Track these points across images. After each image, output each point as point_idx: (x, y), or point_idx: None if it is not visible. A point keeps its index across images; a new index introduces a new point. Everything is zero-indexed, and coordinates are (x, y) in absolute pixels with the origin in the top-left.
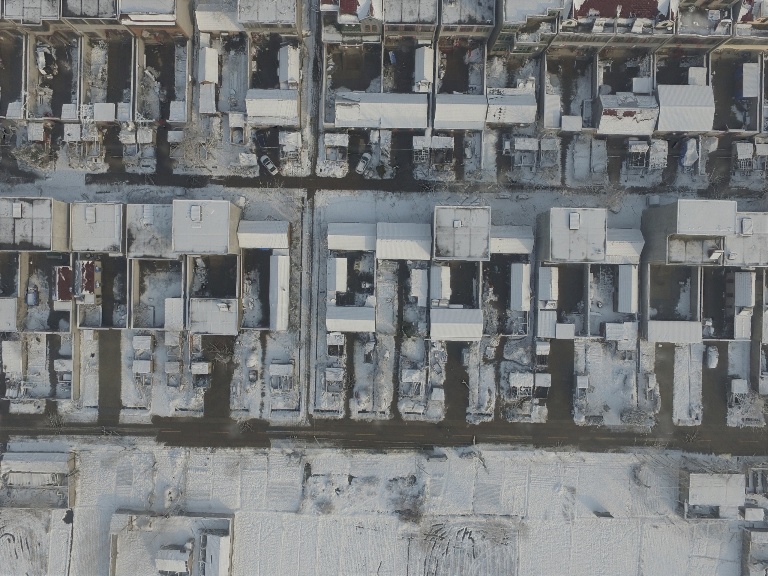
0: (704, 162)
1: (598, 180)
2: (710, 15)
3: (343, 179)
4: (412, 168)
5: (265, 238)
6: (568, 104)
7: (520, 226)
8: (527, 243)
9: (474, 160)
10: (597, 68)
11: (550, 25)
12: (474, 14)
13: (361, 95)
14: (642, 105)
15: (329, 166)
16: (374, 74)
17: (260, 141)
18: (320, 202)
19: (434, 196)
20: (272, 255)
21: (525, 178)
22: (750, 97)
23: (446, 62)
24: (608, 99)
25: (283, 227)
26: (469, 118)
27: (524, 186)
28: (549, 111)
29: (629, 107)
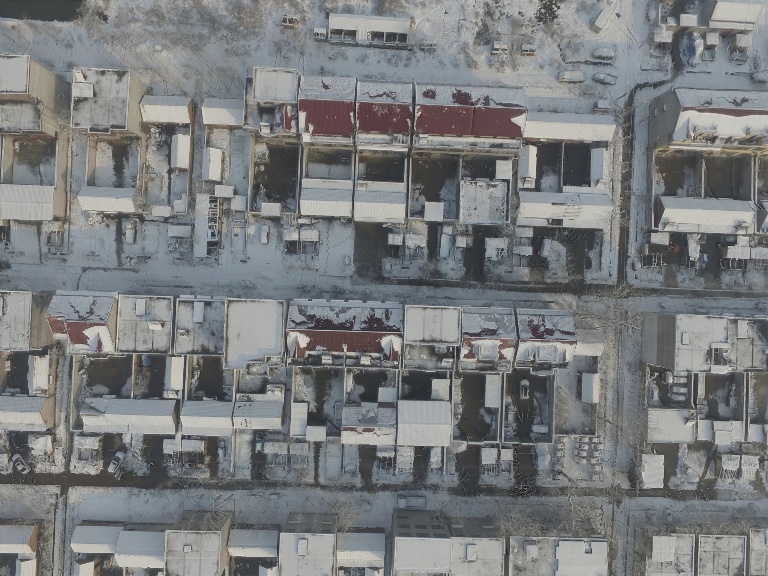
0: (453, 462)
1: (349, 480)
2: (437, 349)
3: (97, 476)
4: (166, 465)
5: (7, 547)
6: (321, 405)
7: (267, 530)
8: (270, 551)
9: (228, 458)
10: (344, 377)
11: (281, 357)
12: (207, 344)
13: (109, 402)
14: (381, 421)
15: (82, 465)
16: (130, 372)
17: (10, 443)
18: (74, 498)
19: (188, 493)
20: (17, 559)
21: (278, 476)
22: (492, 407)
23: (202, 361)
24: (350, 413)
25: (26, 535)
26: (216, 426)
27: (278, 483)
28: (296, 419)
29: (368, 424)
